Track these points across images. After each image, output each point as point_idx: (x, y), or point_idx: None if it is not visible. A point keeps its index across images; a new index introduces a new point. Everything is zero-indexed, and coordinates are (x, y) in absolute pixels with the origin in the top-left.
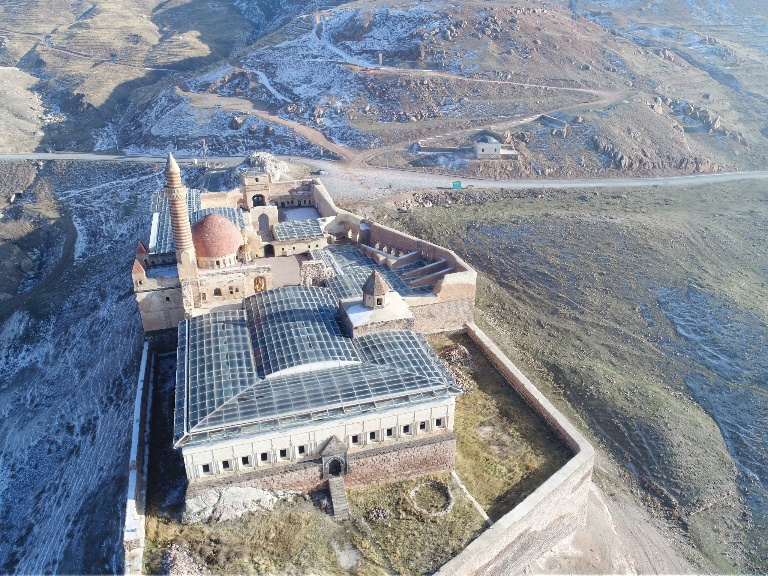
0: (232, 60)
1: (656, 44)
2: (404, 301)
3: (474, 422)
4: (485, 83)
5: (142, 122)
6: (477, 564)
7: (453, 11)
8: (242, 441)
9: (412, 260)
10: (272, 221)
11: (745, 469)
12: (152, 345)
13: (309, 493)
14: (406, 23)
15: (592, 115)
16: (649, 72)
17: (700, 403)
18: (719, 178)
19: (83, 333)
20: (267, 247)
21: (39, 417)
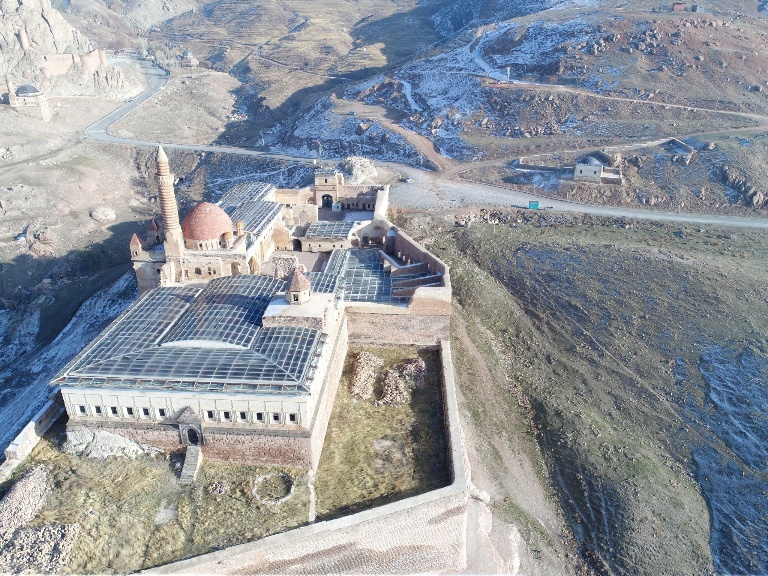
0: (387, 71)
1: None
2: (329, 302)
3: (378, 433)
4: (619, 101)
5: (297, 124)
6: (271, 556)
7: (608, 24)
8: (108, 392)
9: (416, 271)
10: (311, 219)
11: (724, 570)
12: None
13: (171, 454)
14: (557, 37)
15: (730, 142)
16: None
17: (699, 482)
18: None
19: None
20: (295, 241)
21: None
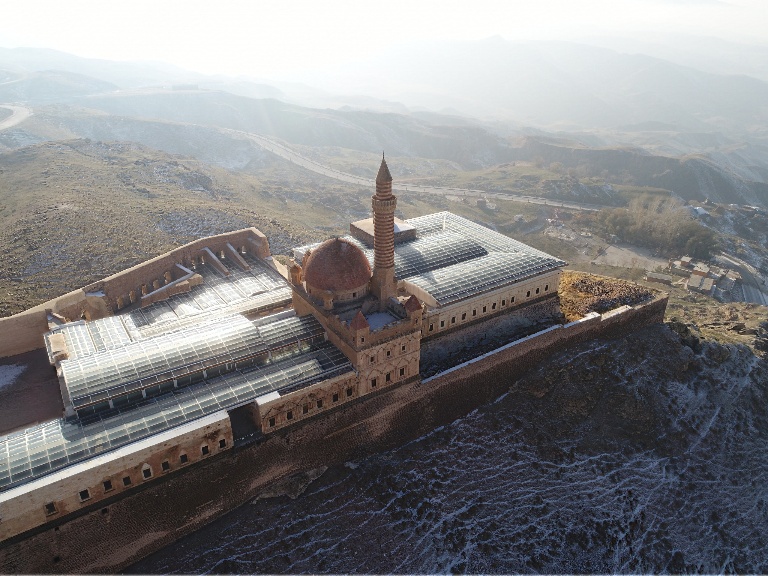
0: None
1: None
2: None
3: None
4: None
5: None
6: None
7: None
8: None
9: None
10: None
11: None
12: None
13: None
14: None
15: None
16: None
17: None
18: None
19: None
20: None
21: None
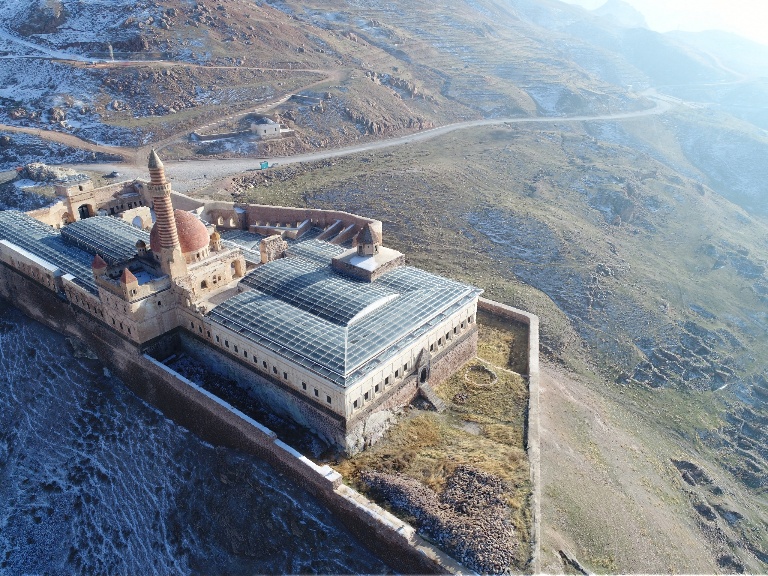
0: None
1: (336, 27)
2: None
3: None
4: (225, 70)
5: None
6: None
7: None
8: (377, 370)
9: (306, 228)
10: (146, 223)
11: (572, 316)
12: (150, 356)
13: (410, 403)
14: (107, 12)
15: (336, 91)
16: (349, 51)
17: (529, 284)
18: (439, 131)
19: None
20: None
21: None
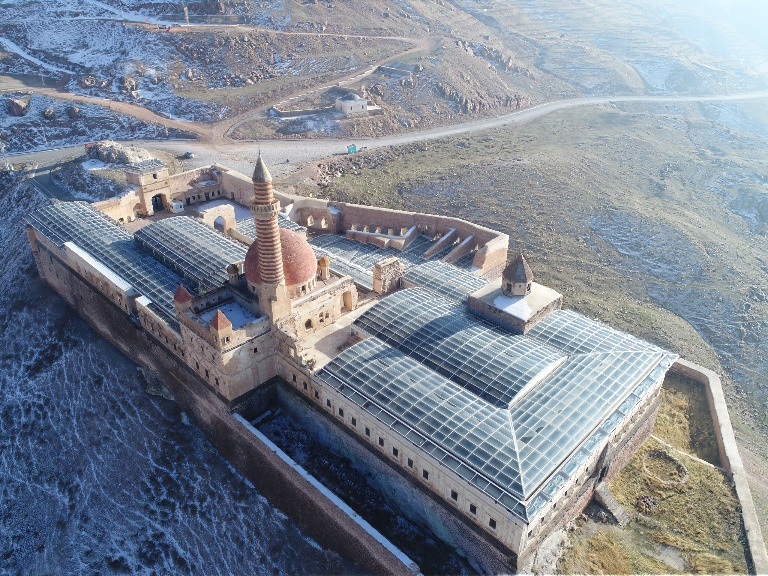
0: None
1: None
2: None
3: None
4: (306, 36)
5: None
6: None
7: None
8: None
9: (413, 236)
10: (229, 224)
11: (721, 351)
12: (241, 415)
13: (583, 512)
14: None
15: (427, 62)
16: (436, 17)
17: (667, 308)
18: (539, 111)
19: (0, 433)
20: None
21: (35, 569)
